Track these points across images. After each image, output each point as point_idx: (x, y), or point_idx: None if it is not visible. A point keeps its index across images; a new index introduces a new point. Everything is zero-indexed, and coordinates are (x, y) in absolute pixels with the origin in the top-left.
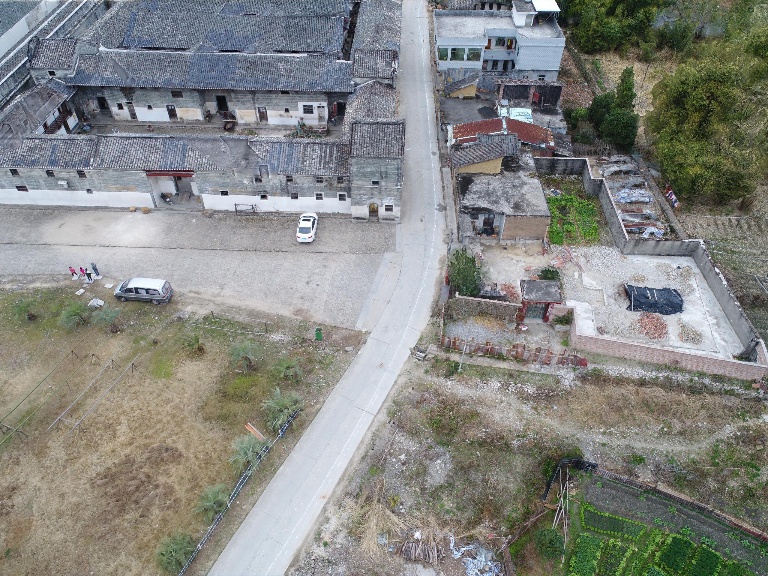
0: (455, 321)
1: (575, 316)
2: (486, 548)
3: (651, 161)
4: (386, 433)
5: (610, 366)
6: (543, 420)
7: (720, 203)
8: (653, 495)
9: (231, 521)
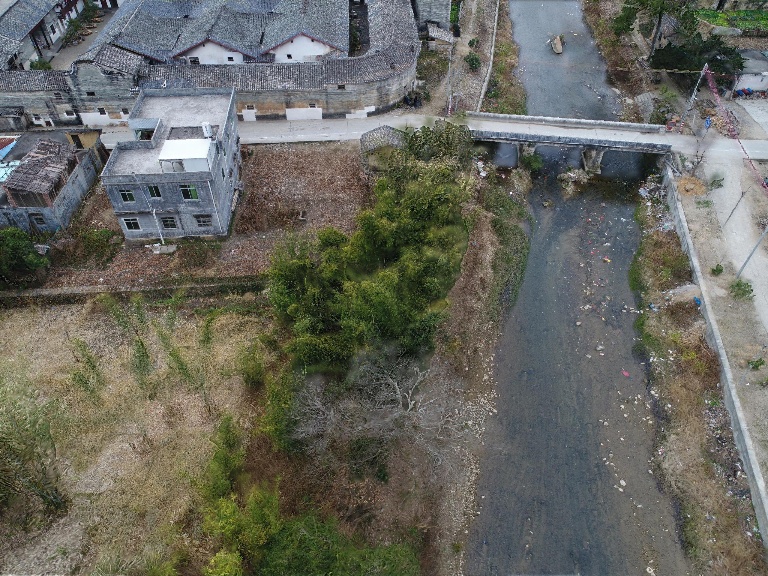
0: None
1: None
2: None
3: None
4: None
5: None
6: None
7: None
8: None
9: None
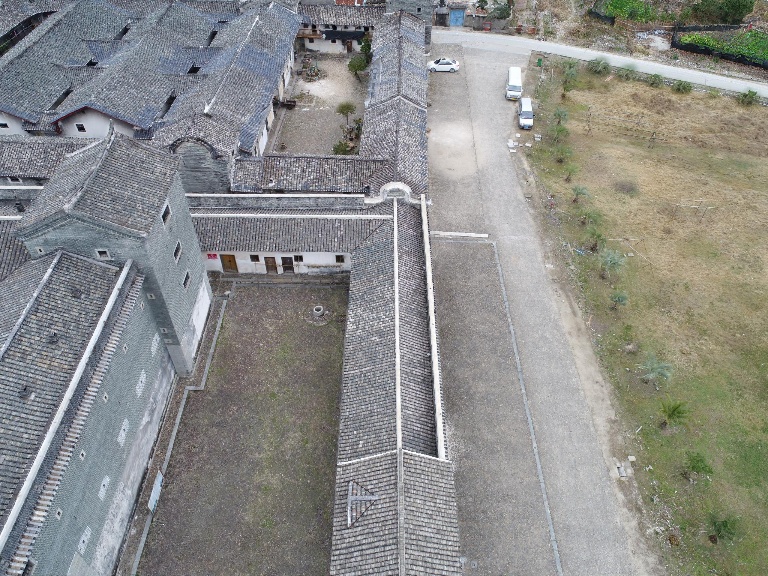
0: None
1: None
2: None
3: None
4: None
5: (533, 4)
6: None
7: None
8: None
9: None
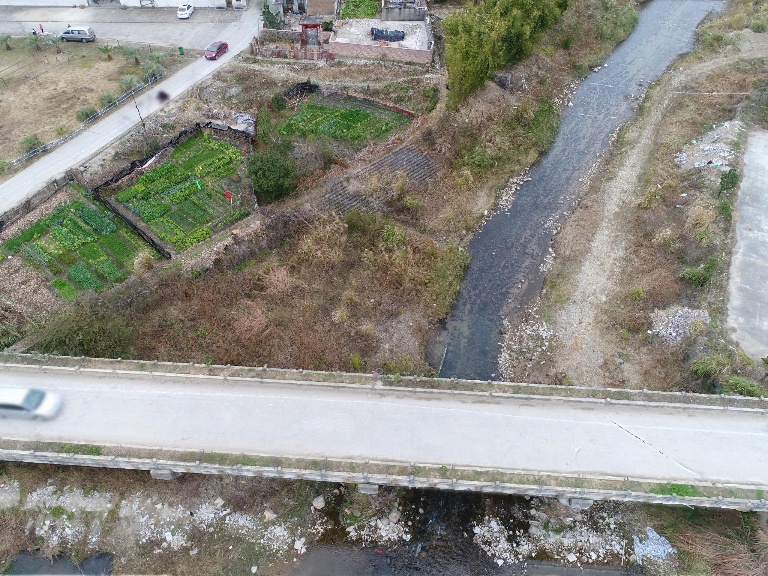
0: (265, 45)
1: (331, 35)
2: (250, 114)
3: None
4: (209, 81)
5: None
6: (300, 77)
7: (461, 3)
8: (348, 100)
9: (118, 108)
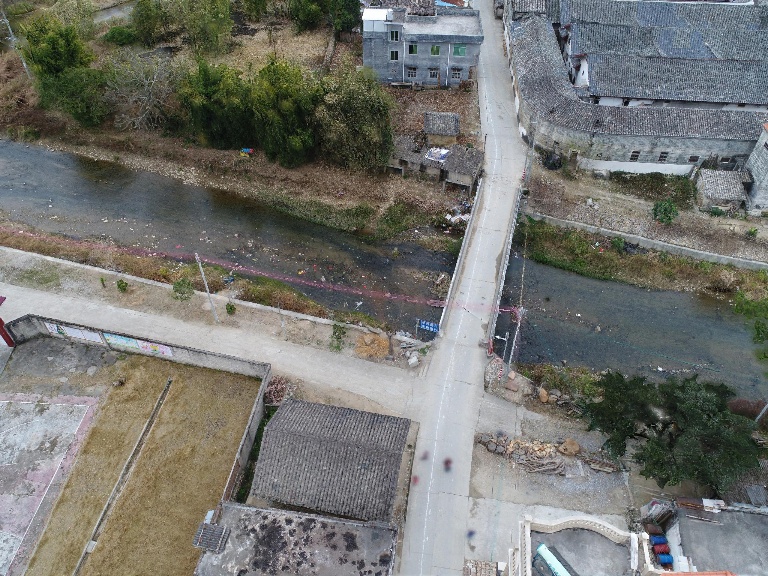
0: None
1: None
2: None
3: (327, 24)
4: None
5: None
6: None
7: None
8: None
9: None
